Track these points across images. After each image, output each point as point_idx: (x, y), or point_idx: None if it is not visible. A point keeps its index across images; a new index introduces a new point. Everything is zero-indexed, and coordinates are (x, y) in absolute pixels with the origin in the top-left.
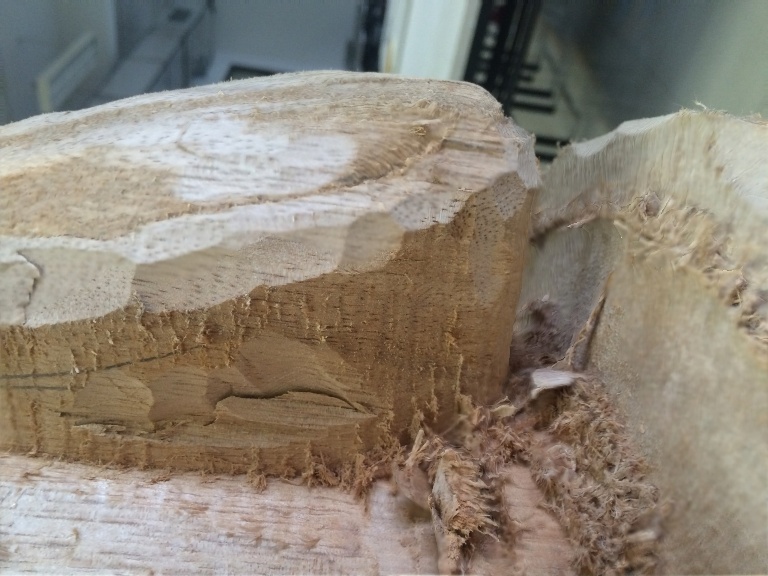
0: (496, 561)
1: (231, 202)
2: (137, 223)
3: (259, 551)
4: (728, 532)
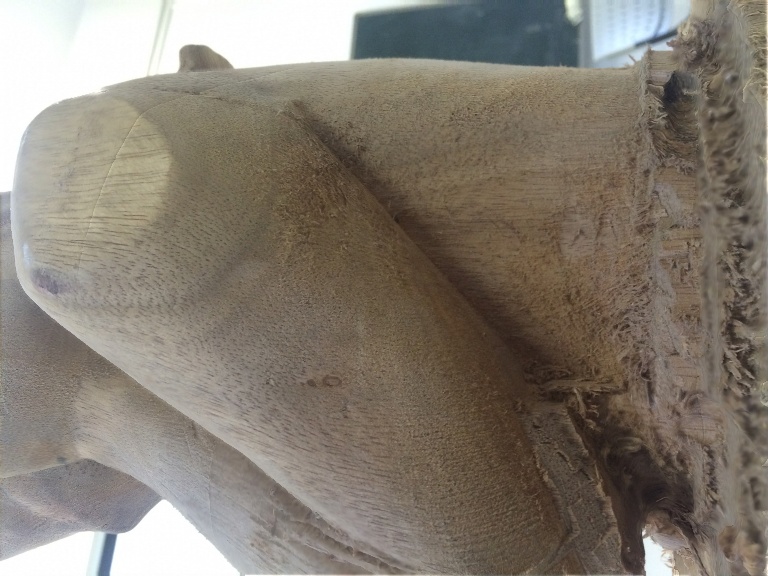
0: None
1: None
2: None
3: None
4: None
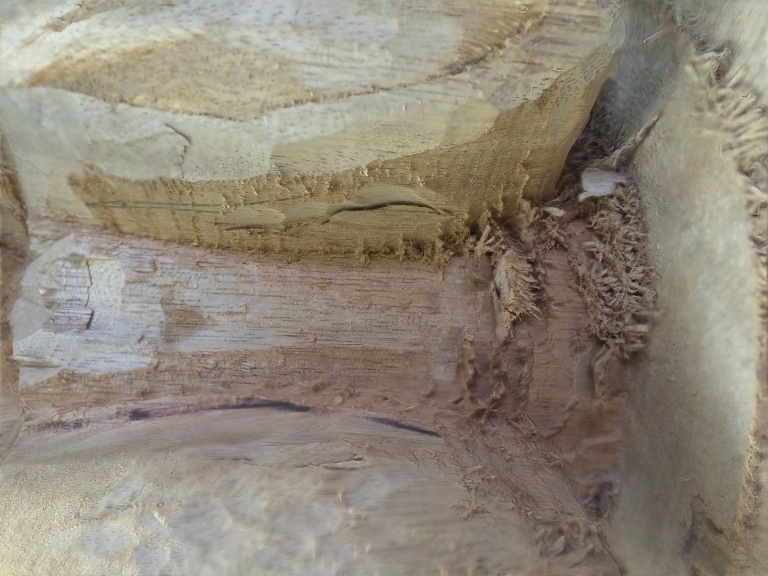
0: (534, 323)
1: (349, 91)
2: (267, 108)
3: (370, 311)
4: (693, 351)
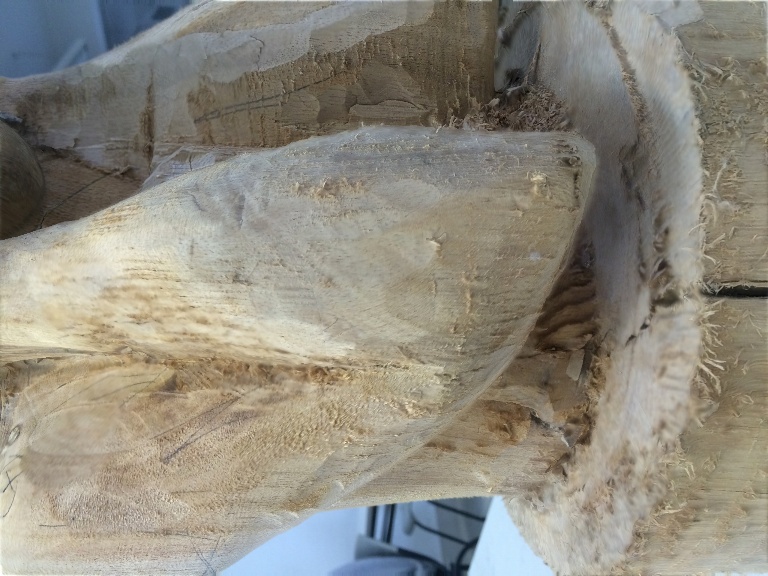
0: None
1: None
2: (307, 13)
3: None
4: (590, 95)
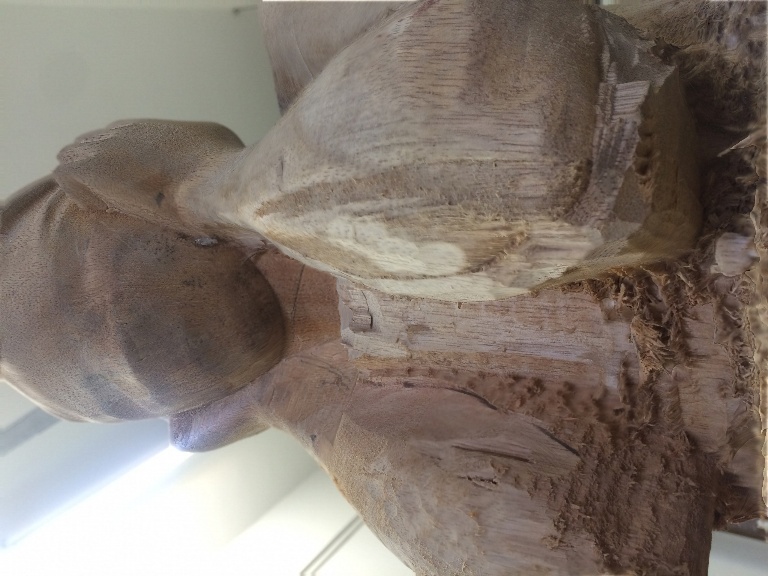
0: (681, 367)
1: (411, 277)
2: (373, 276)
3: (544, 332)
4: None
